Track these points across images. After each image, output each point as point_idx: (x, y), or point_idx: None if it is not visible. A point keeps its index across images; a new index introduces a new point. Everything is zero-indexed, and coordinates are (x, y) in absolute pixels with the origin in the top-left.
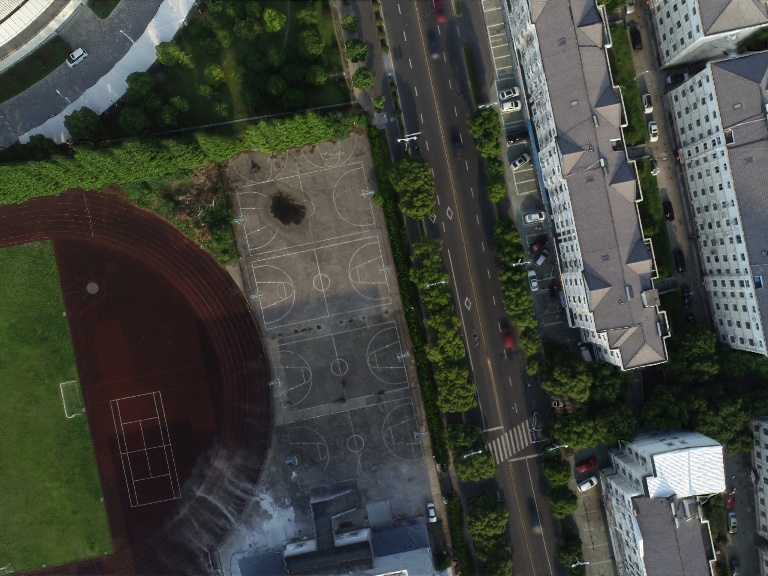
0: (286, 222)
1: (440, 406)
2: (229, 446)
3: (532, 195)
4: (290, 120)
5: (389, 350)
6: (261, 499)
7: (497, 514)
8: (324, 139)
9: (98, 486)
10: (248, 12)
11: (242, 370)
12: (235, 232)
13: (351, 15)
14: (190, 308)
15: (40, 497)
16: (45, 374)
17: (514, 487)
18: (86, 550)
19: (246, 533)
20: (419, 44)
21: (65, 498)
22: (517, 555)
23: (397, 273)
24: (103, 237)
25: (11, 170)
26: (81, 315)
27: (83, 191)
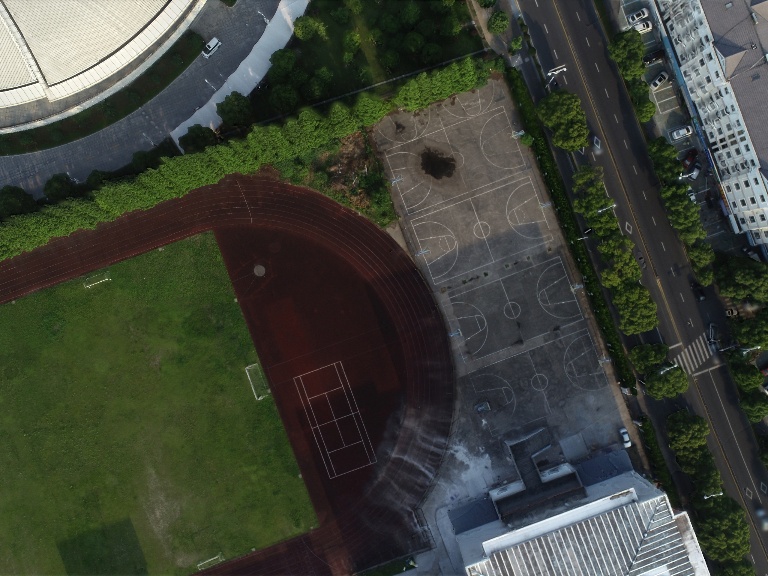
0: (438, 176)
1: (624, 330)
2: (416, 404)
3: (675, 112)
4: (428, 76)
5: (558, 286)
6: (455, 451)
7: (699, 425)
8: (470, 87)
9: (294, 463)
10: None
11: (417, 328)
12: (390, 194)
13: None
14: (357, 275)
15: (240, 483)
16: (226, 362)
17: (702, 400)
18: (292, 528)
19: (446, 487)
20: None
21: (264, 480)
22: (716, 466)
23: (555, 209)
24: (262, 219)
25: (190, 158)
26: (252, 299)
27: (236, 177)
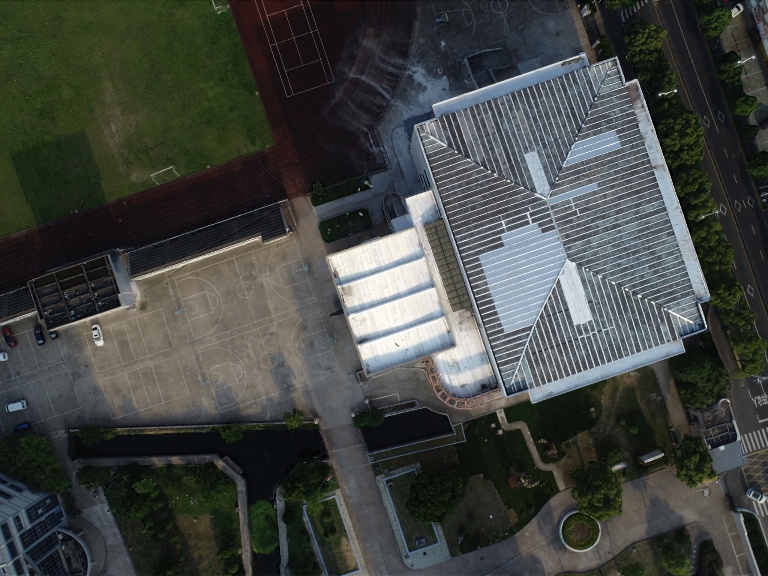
0: None
1: None
2: (375, 24)
3: None
4: None
5: None
6: (413, 72)
7: (656, 26)
8: None
9: (252, 80)
10: None
11: None
12: None
13: None
14: None
15: (196, 98)
16: None
17: None
18: (248, 146)
19: (403, 108)
20: None
21: (221, 96)
22: None
23: None
24: None
25: None
26: None
27: None
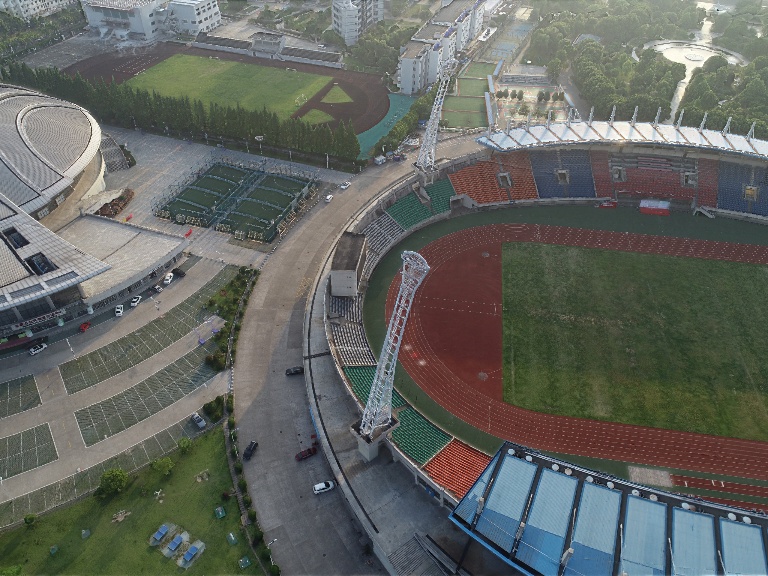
0: None
1: None
2: None
3: None
4: None
5: None
6: None
7: None
8: None
9: None
10: None
11: None
12: None
13: None
14: None
15: None
16: None
17: None
18: None
19: None
20: None
21: None
22: None
23: None
24: None
25: None
26: None
27: None
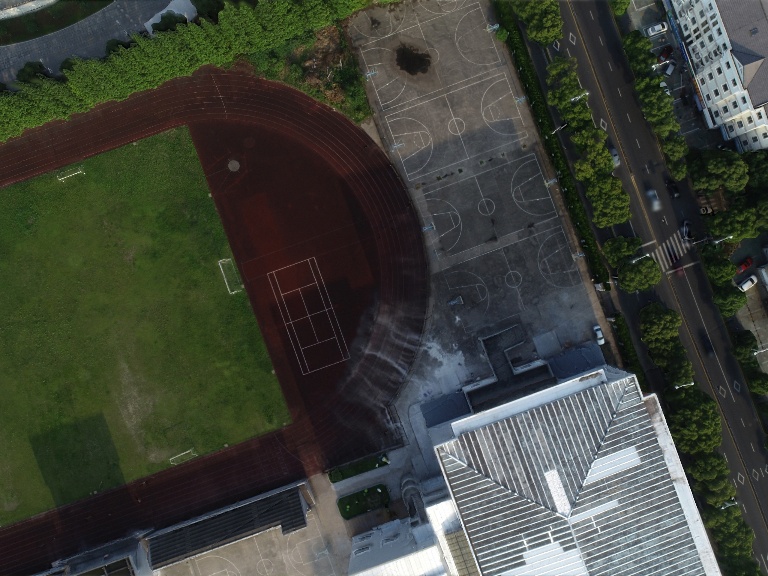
0: (413, 72)
1: (597, 222)
2: (390, 301)
3: (650, 9)
4: None
5: (532, 183)
6: (429, 348)
7: (671, 316)
8: None
9: (268, 359)
10: None
11: (391, 224)
12: (365, 90)
13: None
14: (332, 171)
15: (213, 378)
16: (200, 257)
17: (676, 298)
18: (265, 424)
19: (419, 383)
20: None
21: (237, 376)
22: None
23: (530, 105)
24: (237, 114)
25: (160, 34)
26: (226, 194)
27: (211, 72)
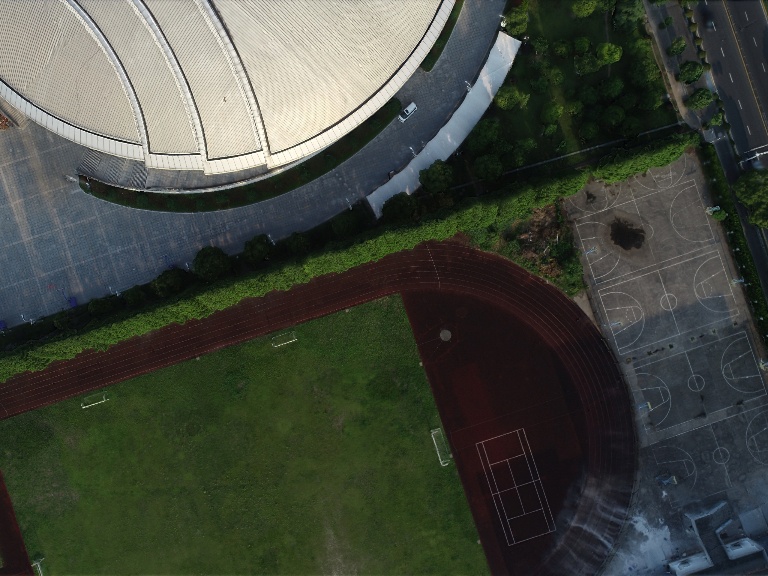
0: (627, 247)
1: None
2: (597, 474)
3: None
4: None
5: (742, 360)
6: (635, 522)
7: None
8: (670, 162)
9: (474, 529)
10: (578, 48)
11: (601, 397)
12: None
13: (683, 38)
14: (543, 343)
15: (418, 547)
16: (409, 425)
17: None
18: None
19: (624, 557)
20: (737, 58)
21: (443, 545)
22: None
23: (742, 284)
24: (450, 284)
25: (412, 231)
26: (437, 363)
27: (426, 241)
